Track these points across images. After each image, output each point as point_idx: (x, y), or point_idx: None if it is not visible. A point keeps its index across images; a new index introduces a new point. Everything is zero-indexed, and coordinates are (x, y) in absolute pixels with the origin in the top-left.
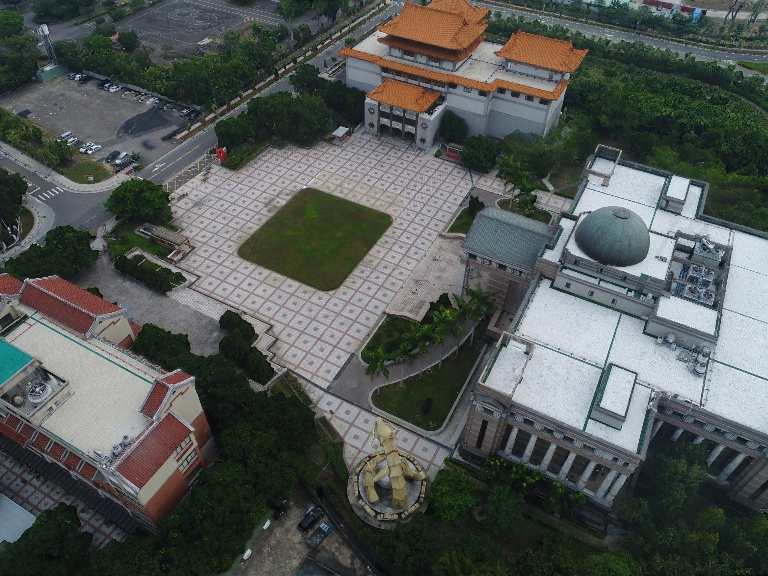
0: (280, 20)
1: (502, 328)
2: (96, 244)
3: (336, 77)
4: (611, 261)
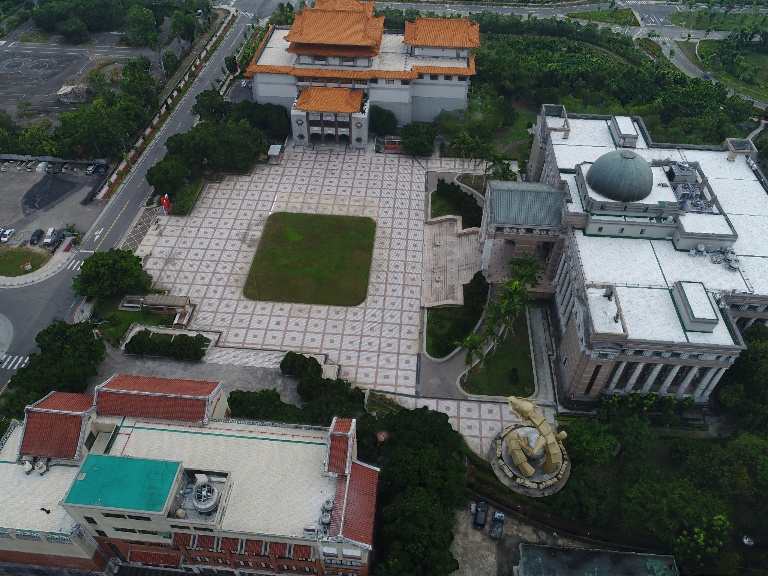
0: (131, 52)
1: (537, 287)
2: None
3: (230, 98)
4: (632, 198)
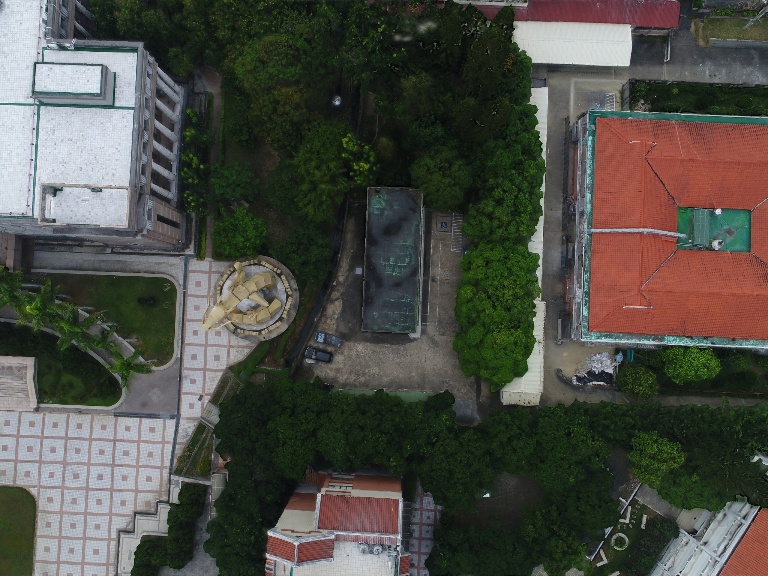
0: None
1: (2, 257)
2: None
3: None
4: None
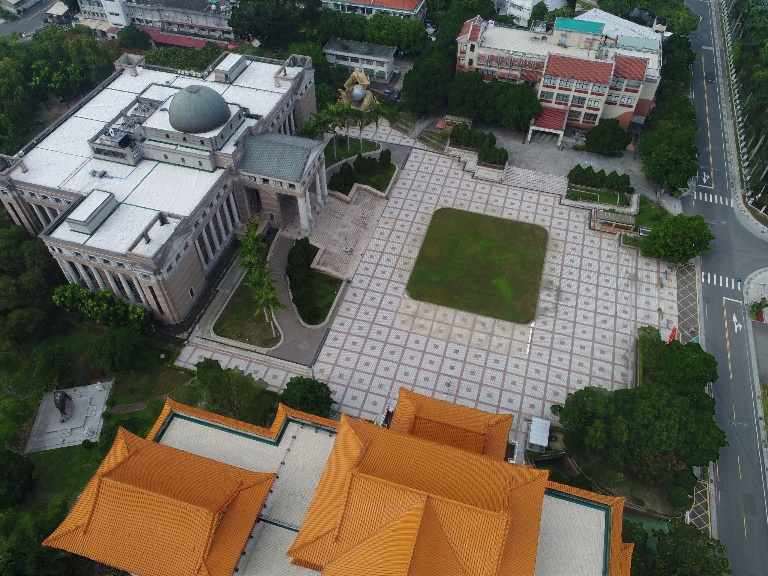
0: None
1: None
2: (677, 211)
3: None
4: None
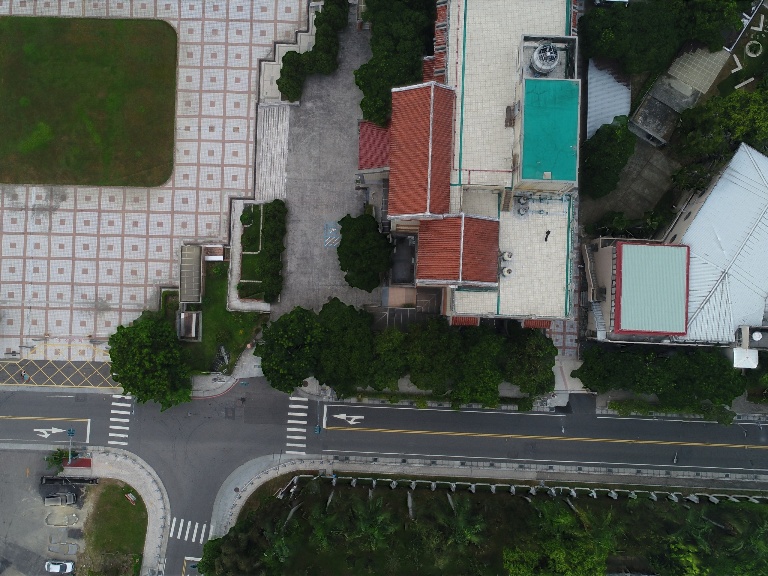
0: None
1: None
2: (249, 368)
3: None
4: None
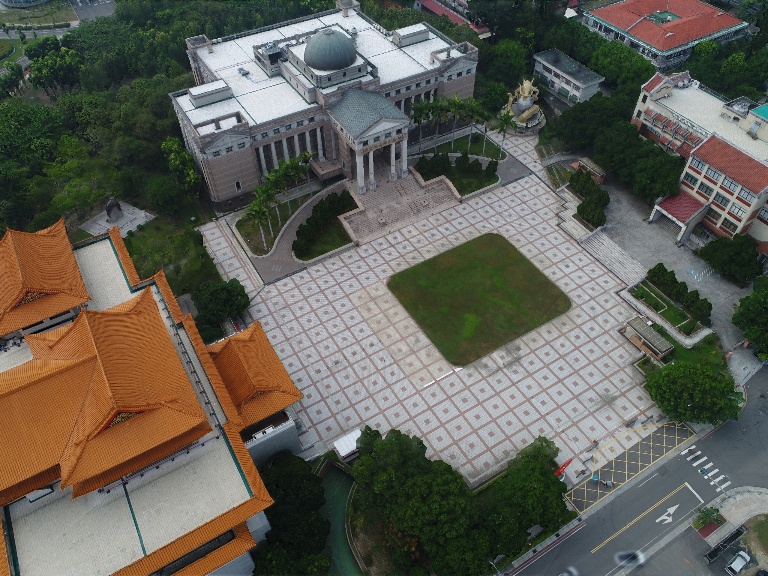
0: None
1: None
2: (742, 373)
3: None
4: None
